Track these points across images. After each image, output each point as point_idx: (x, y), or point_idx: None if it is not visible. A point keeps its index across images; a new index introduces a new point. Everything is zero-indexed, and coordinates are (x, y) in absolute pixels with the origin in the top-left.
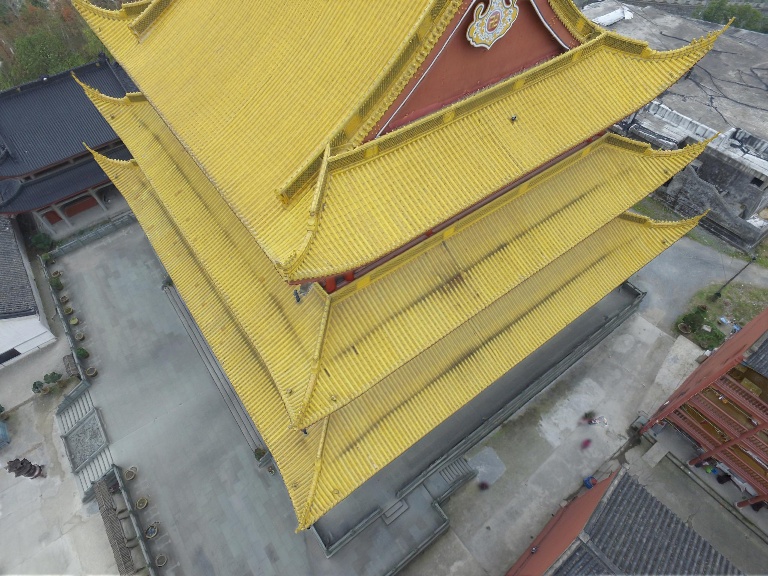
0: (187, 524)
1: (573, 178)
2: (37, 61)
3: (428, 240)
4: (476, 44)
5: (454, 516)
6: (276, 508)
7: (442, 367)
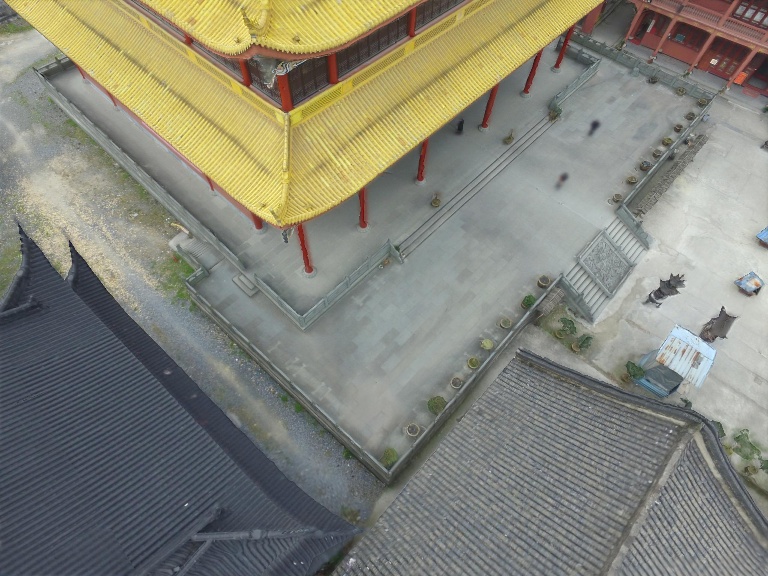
0: (625, 151)
1: None
2: None
3: None
4: None
5: None
6: (583, 104)
7: None
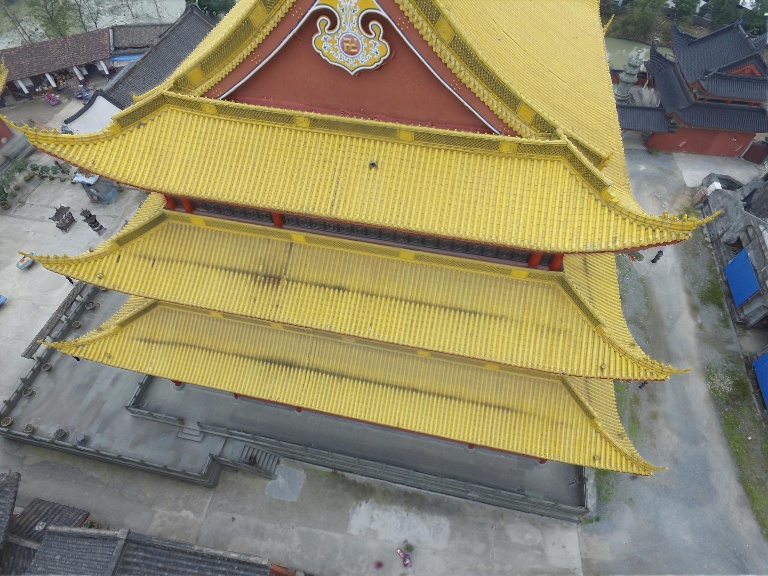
0: None
1: (482, 288)
2: None
3: (270, 229)
4: (331, 60)
5: (226, 485)
6: None
7: (259, 353)
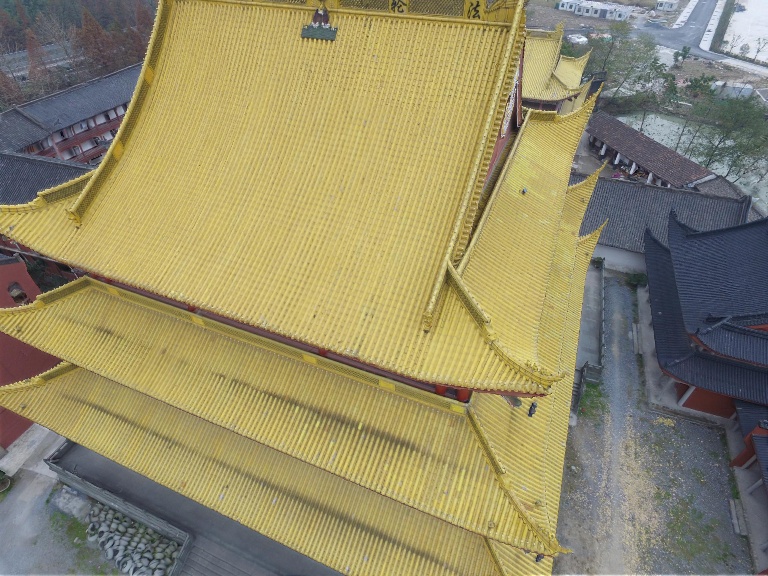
0: None
1: None
2: None
3: None
4: None
5: None
6: None
7: None
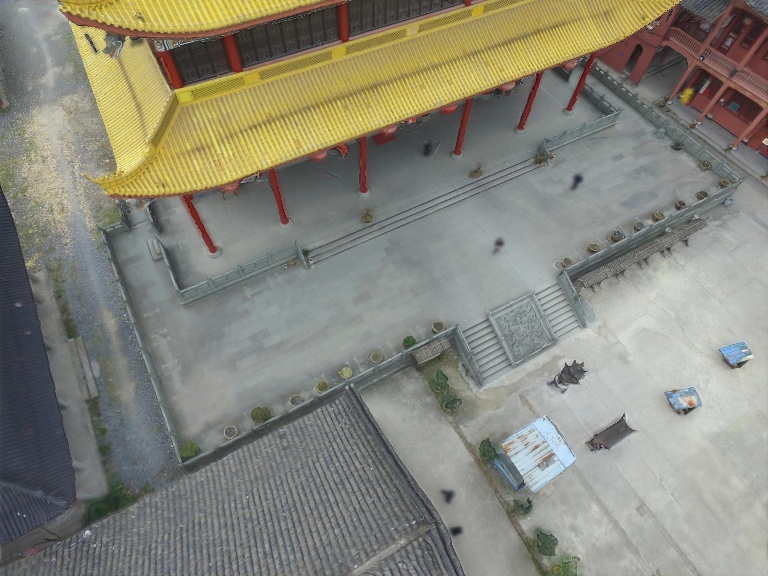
0: (604, 215)
1: None
2: None
3: None
4: None
5: None
6: (582, 154)
7: None
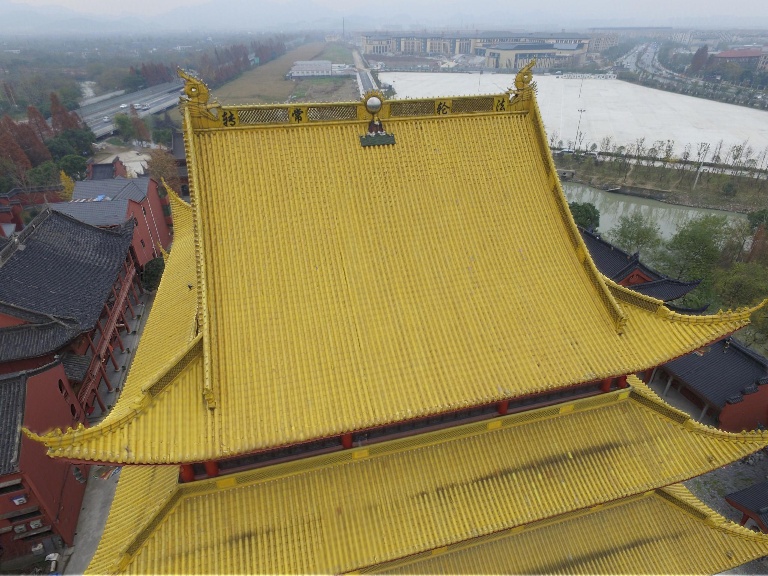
0: None
1: None
2: (679, 251)
3: None
4: None
5: None
6: None
7: None
